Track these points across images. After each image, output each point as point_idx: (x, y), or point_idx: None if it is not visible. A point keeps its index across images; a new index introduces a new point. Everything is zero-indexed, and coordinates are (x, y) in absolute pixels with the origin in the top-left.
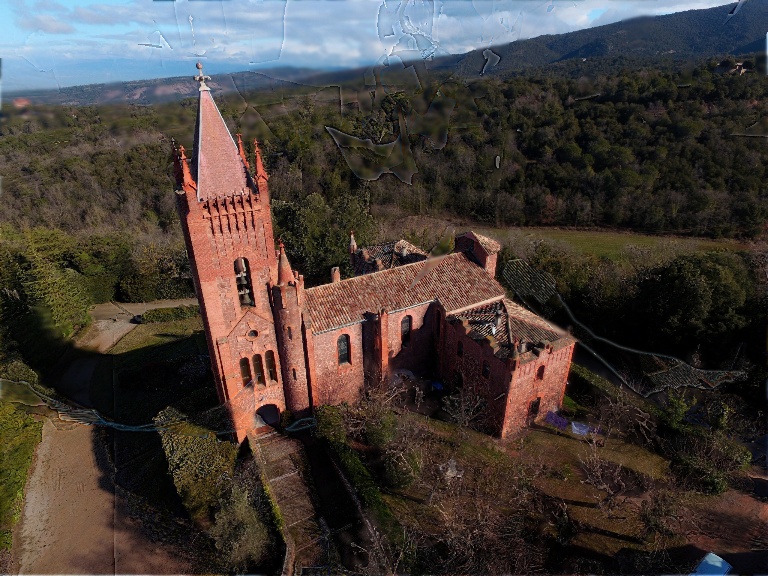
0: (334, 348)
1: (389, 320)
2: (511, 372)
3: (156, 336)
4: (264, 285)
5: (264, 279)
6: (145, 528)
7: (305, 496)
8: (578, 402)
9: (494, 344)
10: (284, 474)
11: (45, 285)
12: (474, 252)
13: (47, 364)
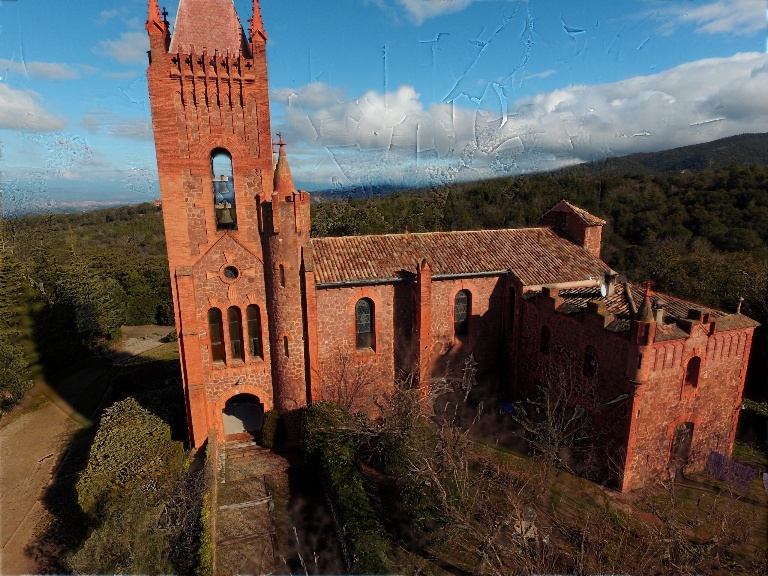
0: (350, 318)
1: (436, 291)
2: (640, 348)
3: (176, 352)
4: (252, 198)
5: (253, 189)
6: (34, 563)
7: (267, 540)
8: (762, 455)
9: (604, 312)
10: (245, 501)
11: (76, 285)
12: (567, 228)
13: (49, 365)
